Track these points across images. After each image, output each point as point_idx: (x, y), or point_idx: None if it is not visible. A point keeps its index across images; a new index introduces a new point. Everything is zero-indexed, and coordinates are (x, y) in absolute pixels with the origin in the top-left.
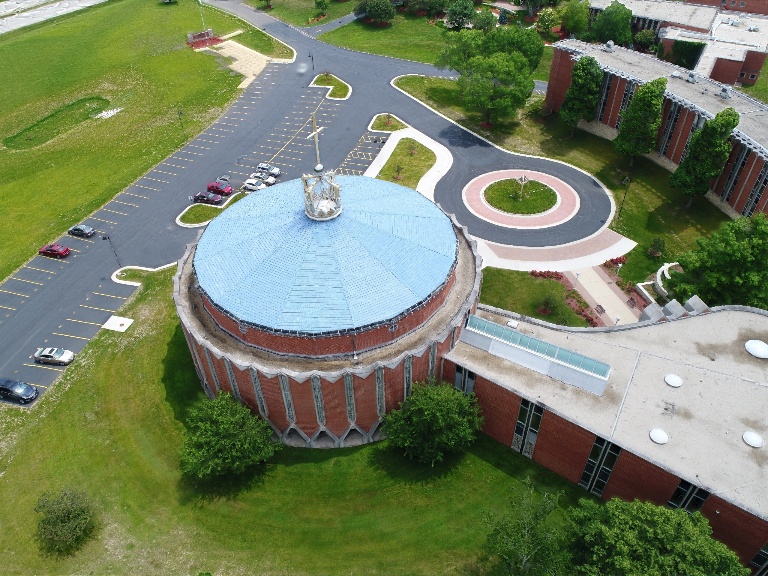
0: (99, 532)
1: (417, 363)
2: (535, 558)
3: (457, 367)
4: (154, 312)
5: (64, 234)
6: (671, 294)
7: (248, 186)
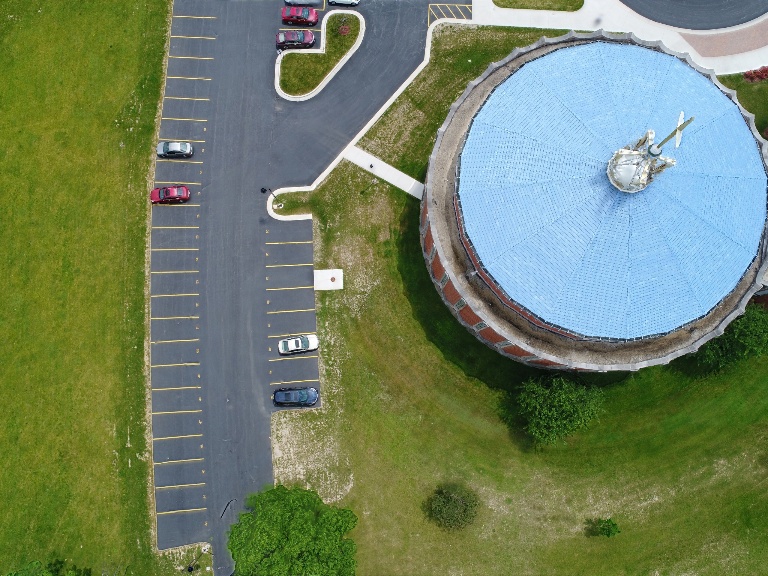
0: (476, 498)
1: None
2: None
3: None
4: (357, 253)
5: (154, 159)
6: None
7: (336, 0)
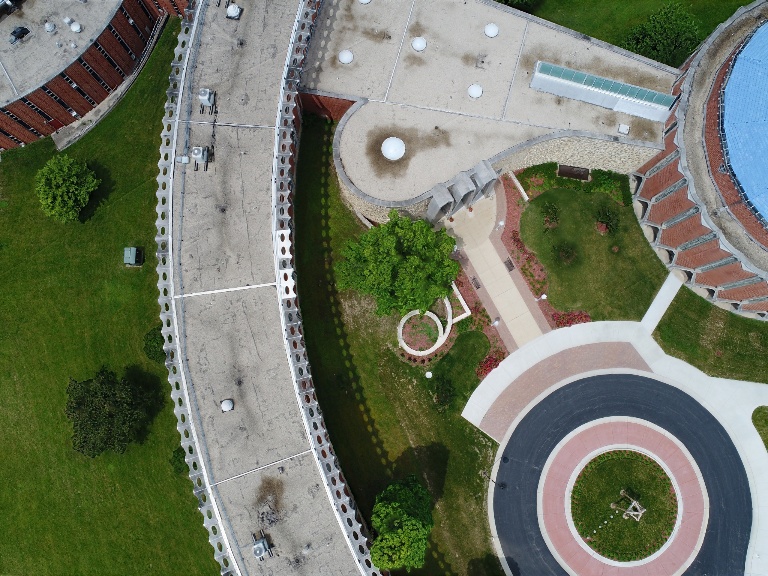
0: None
1: None
2: None
3: None
4: None
5: None
6: None
7: None
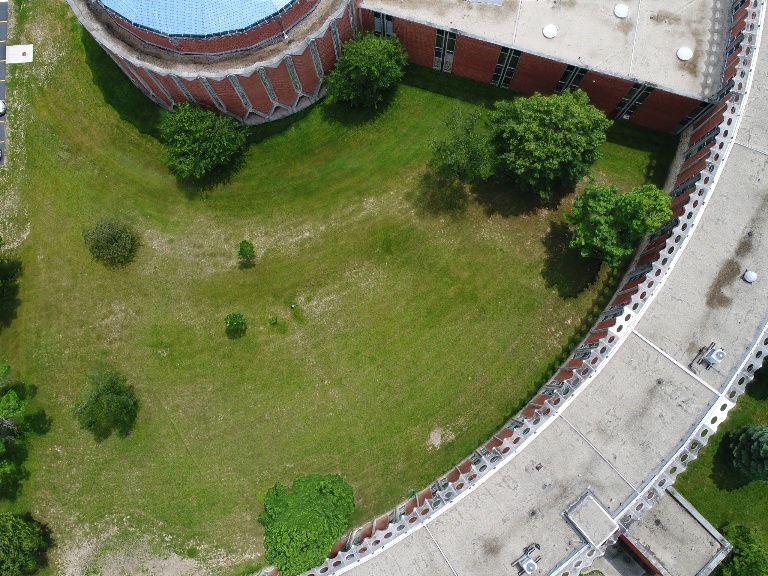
0: (141, 240)
1: (340, 23)
2: (470, 159)
3: (375, 13)
4: (47, 29)
5: None
6: None
7: None
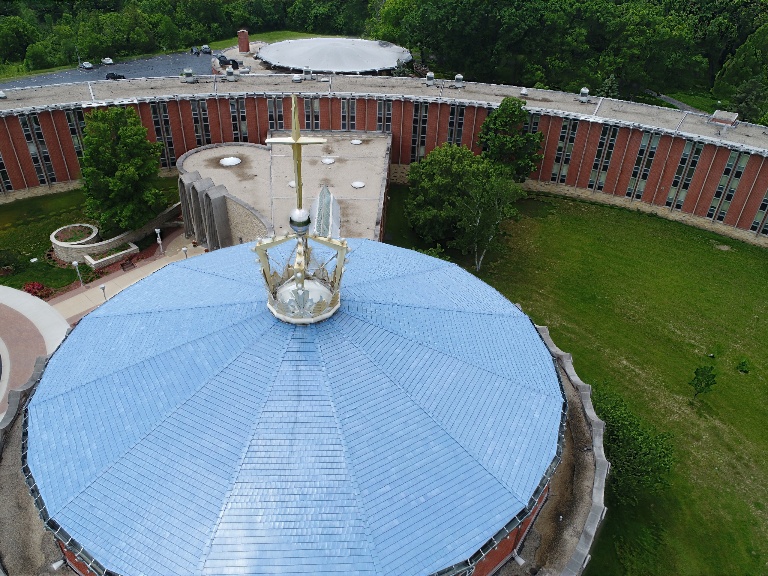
0: None
1: None
2: None
3: None
4: None
5: None
6: (135, 223)
7: None
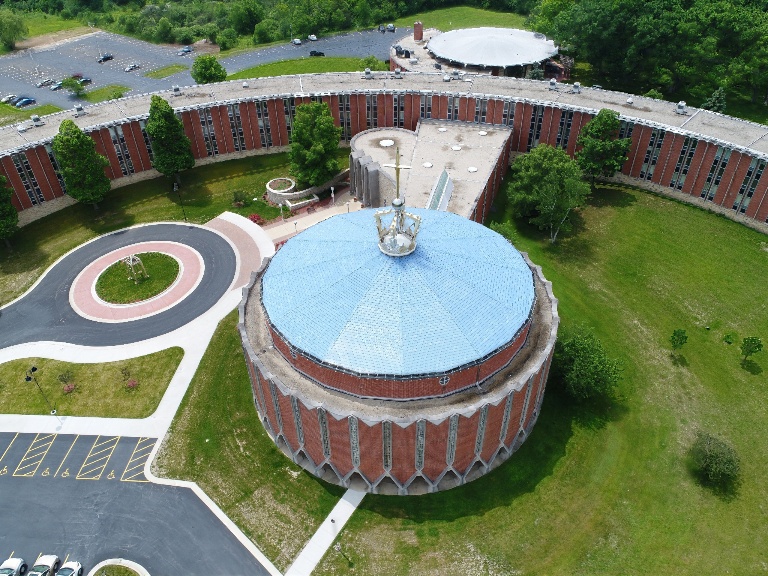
0: None
1: None
2: None
3: None
4: (433, 572)
5: None
6: (319, 182)
7: None
